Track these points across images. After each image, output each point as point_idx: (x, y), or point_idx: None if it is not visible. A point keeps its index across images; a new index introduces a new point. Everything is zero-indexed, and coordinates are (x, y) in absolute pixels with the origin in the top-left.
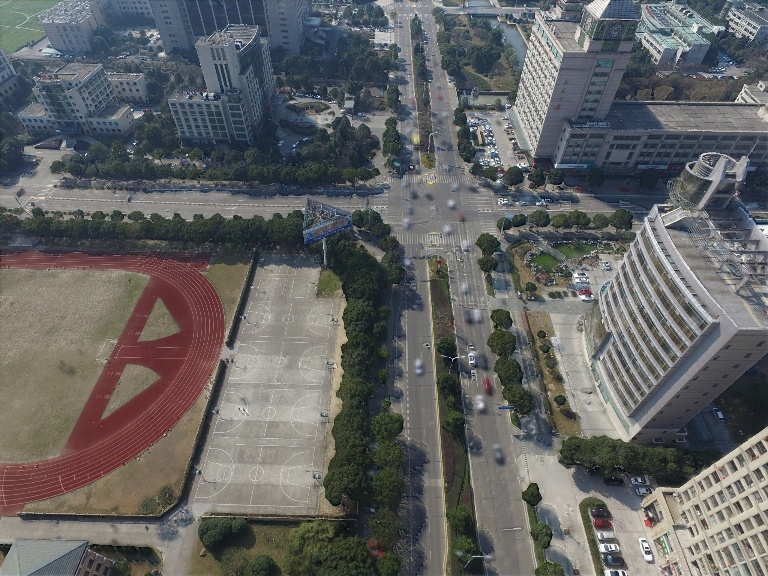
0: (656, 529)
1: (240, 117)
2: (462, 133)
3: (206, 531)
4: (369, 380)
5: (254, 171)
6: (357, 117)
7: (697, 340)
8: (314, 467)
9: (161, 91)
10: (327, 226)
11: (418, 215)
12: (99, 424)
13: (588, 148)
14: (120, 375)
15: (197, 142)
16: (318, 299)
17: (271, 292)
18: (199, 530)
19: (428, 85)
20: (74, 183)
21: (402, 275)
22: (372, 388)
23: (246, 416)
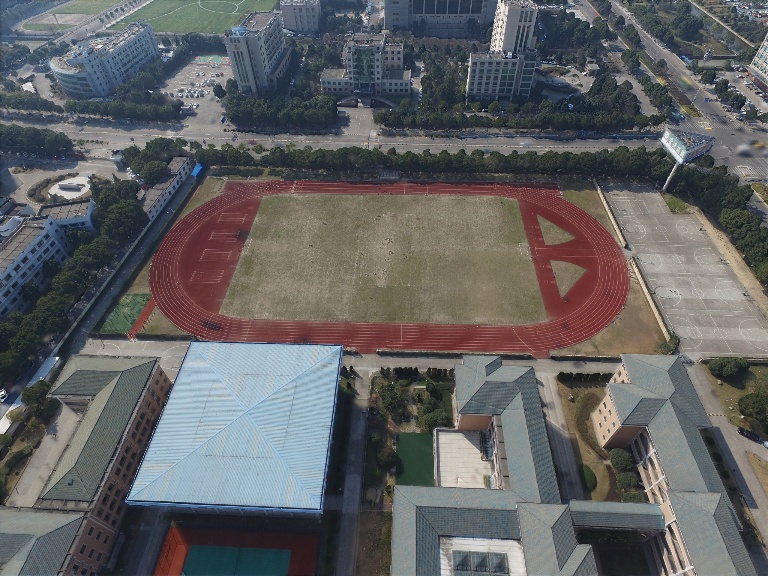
0: None
1: (530, 74)
2: (722, 86)
3: (725, 365)
4: None
5: (559, 118)
6: None
7: None
8: (766, 329)
9: None
10: (700, 148)
11: (716, 153)
12: (563, 300)
13: None
14: (551, 268)
15: (480, 99)
16: (675, 215)
17: (631, 210)
18: (717, 364)
19: (646, 52)
20: (392, 132)
21: (752, 193)
22: None
23: (680, 295)
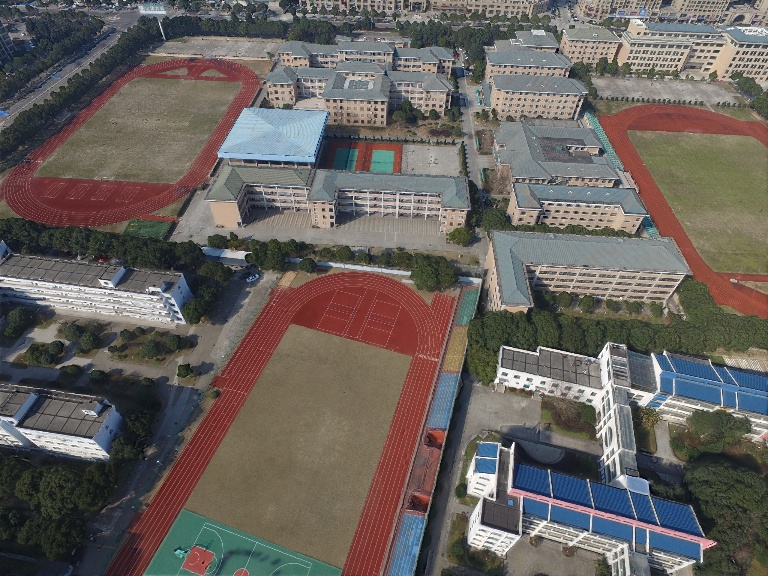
0: (308, 3)
1: (4, 32)
2: None
3: None
4: (239, 34)
5: (67, 43)
6: (15, 31)
7: None
8: None
9: None
10: None
11: None
12: None
13: None
14: (205, 76)
15: None
16: (187, 42)
17: None
18: None
19: None
20: None
21: None
22: None
23: None
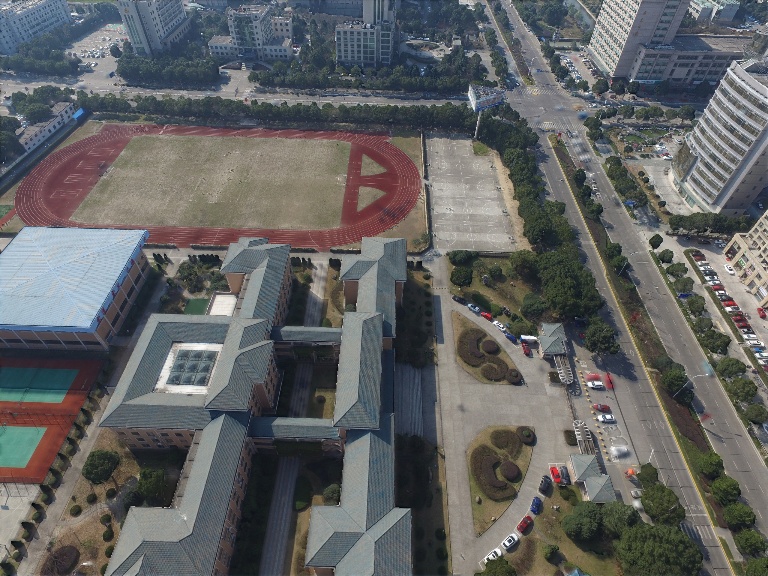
0: (735, 257)
1: (388, 43)
2: (554, 60)
3: (457, 253)
4: None
5: (406, 80)
6: None
7: (767, 124)
8: (508, 234)
9: (302, 33)
10: (490, 99)
11: (532, 112)
12: (357, 213)
13: (657, 66)
14: (358, 191)
15: (349, 65)
16: (477, 156)
17: (442, 152)
18: (452, 253)
19: (512, 33)
20: (264, 90)
21: (537, 139)
22: (538, 192)
23: (453, 211)
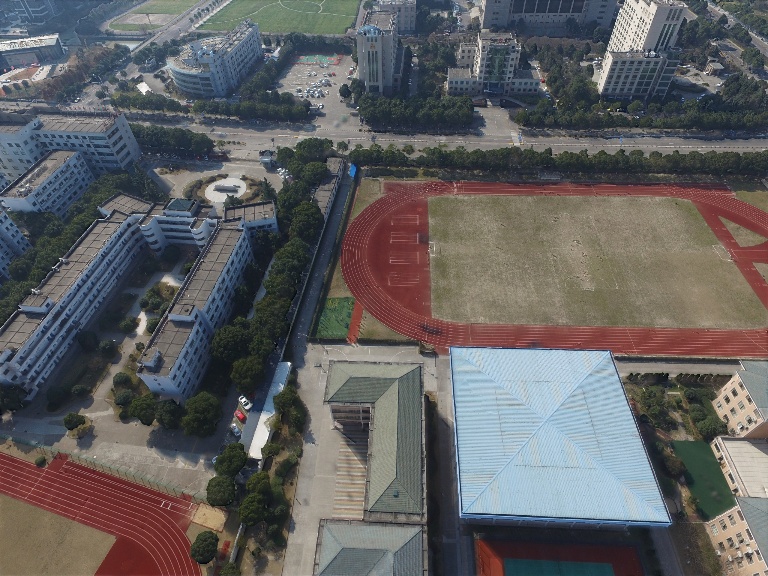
0: None
1: (671, 73)
2: None
3: None
4: None
5: (710, 118)
6: (724, 78)
7: None
8: None
9: (526, 59)
10: None
11: None
12: None
13: None
14: (757, 270)
15: (614, 98)
16: None
17: None
18: None
19: None
20: (533, 132)
21: None
22: None
23: None
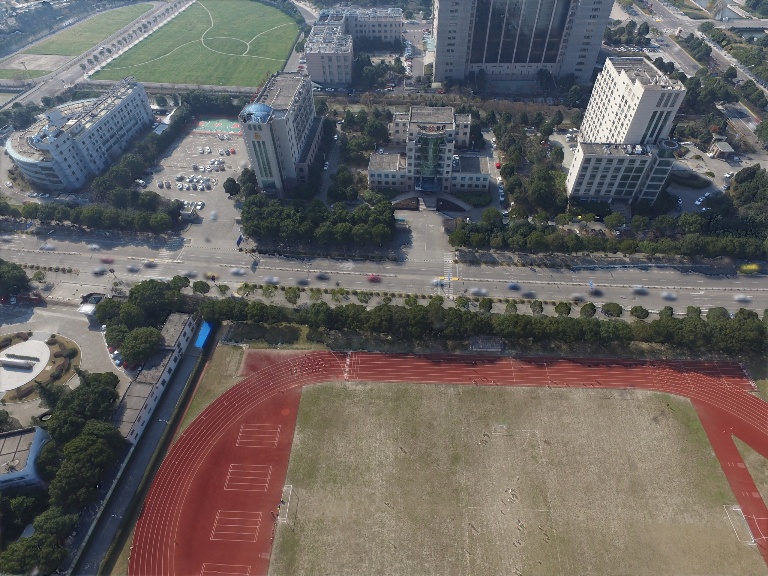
0: None
1: (663, 173)
2: None
3: None
4: None
5: (716, 245)
6: (734, 162)
7: None
8: None
9: (480, 132)
10: None
11: None
12: None
13: None
14: None
15: (587, 201)
16: None
17: None
18: None
19: None
20: (474, 257)
21: None
22: None
23: None
